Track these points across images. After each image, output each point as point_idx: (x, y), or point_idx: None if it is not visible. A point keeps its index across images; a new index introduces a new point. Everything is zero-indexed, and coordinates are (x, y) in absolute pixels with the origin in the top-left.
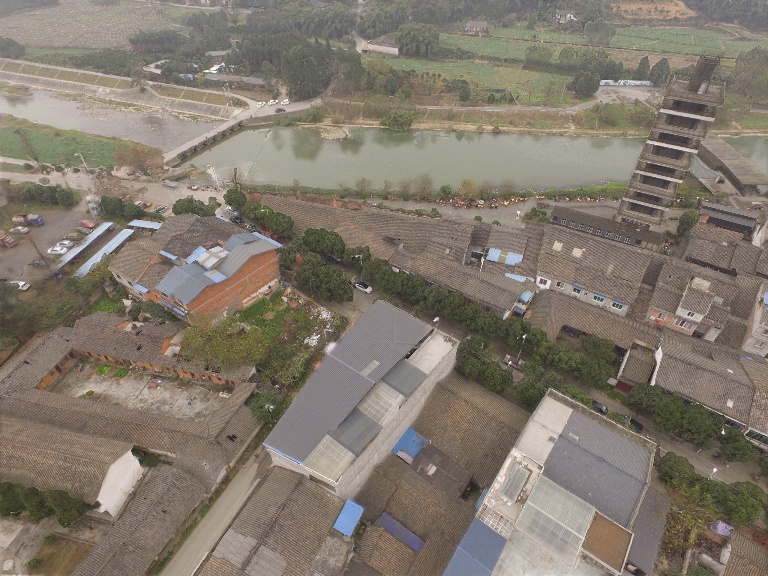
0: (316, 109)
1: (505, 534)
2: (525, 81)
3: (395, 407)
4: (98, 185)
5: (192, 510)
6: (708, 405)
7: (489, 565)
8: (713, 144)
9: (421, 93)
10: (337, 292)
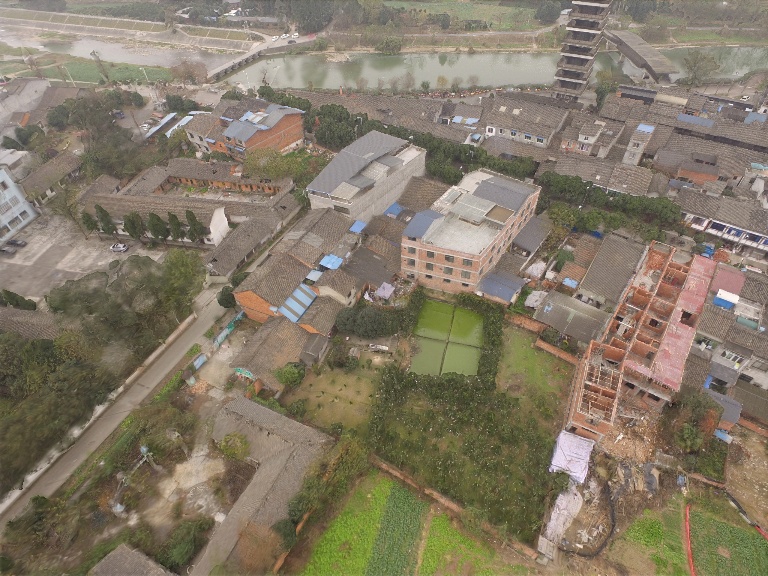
0: (321, 39)
1: (444, 213)
2: (499, 14)
3: (384, 172)
4: (161, 89)
5: (263, 242)
6: (585, 180)
7: (433, 218)
8: (641, 48)
9: (409, 25)
10: (345, 138)
